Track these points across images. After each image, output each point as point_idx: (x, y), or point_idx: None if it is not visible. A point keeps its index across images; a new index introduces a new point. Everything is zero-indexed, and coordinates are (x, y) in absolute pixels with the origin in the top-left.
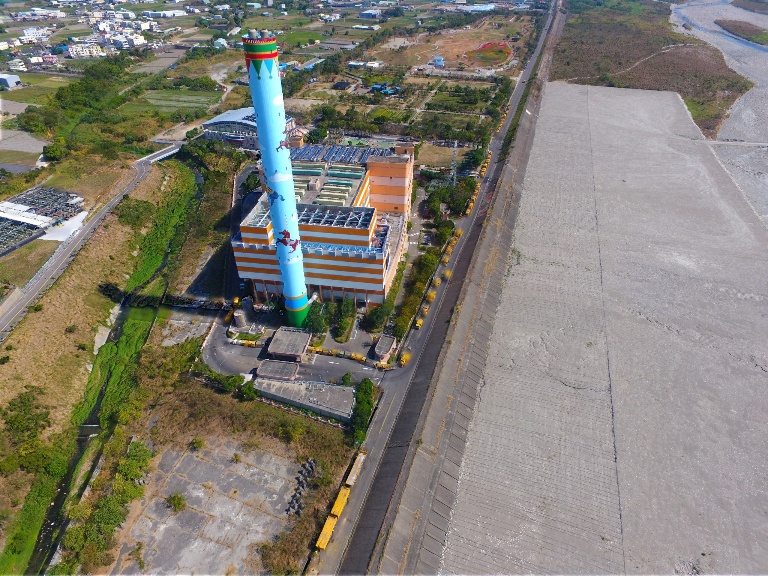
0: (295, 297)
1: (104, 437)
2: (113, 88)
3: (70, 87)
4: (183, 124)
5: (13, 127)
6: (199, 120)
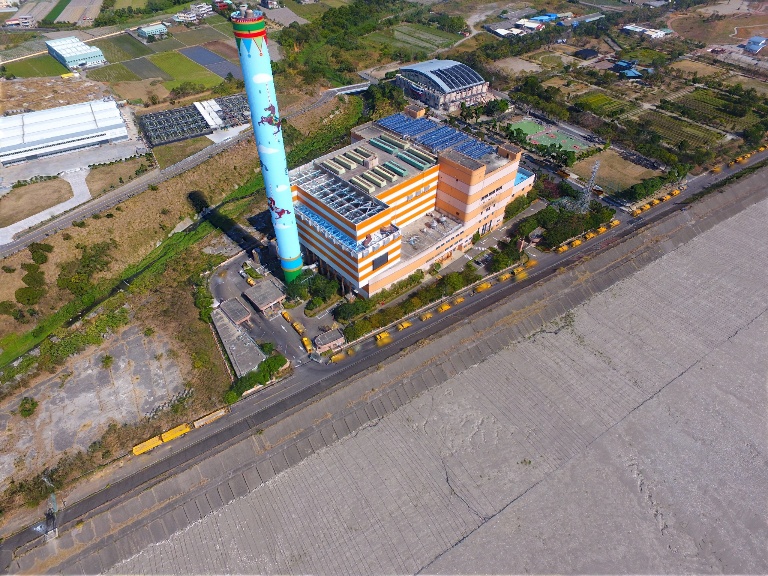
0: (283, 258)
1: None
2: (377, 15)
3: (340, 9)
4: (398, 63)
5: (275, 38)
6: (415, 62)
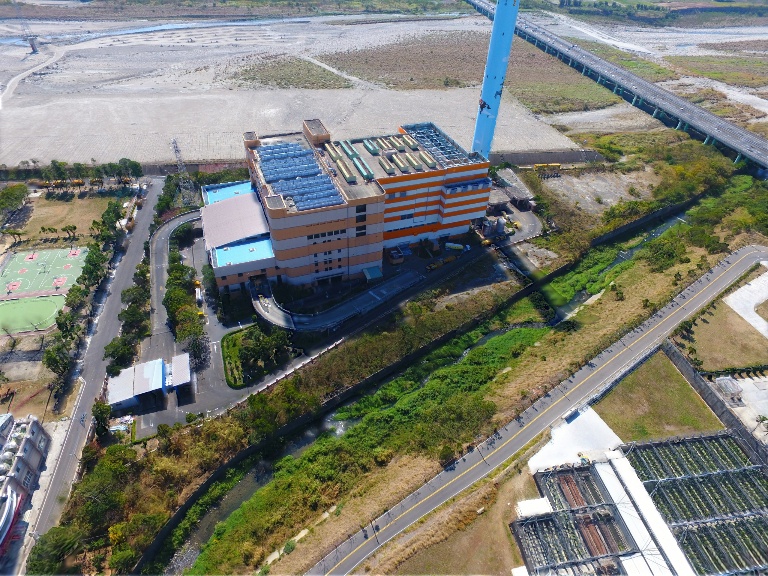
0: None
1: (618, 244)
2: None
3: None
4: None
5: None
6: None
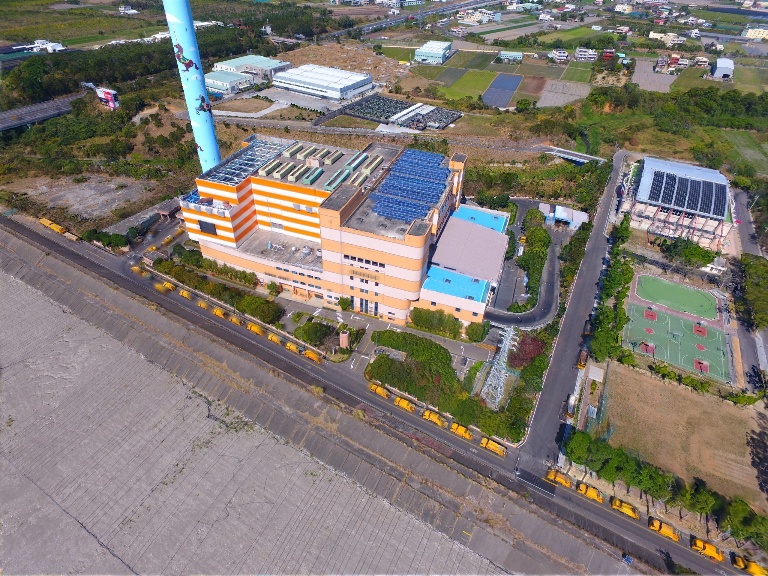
0: None
1: None
2: None
3: (729, 92)
4: (695, 164)
5: None
6: (723, 173)
